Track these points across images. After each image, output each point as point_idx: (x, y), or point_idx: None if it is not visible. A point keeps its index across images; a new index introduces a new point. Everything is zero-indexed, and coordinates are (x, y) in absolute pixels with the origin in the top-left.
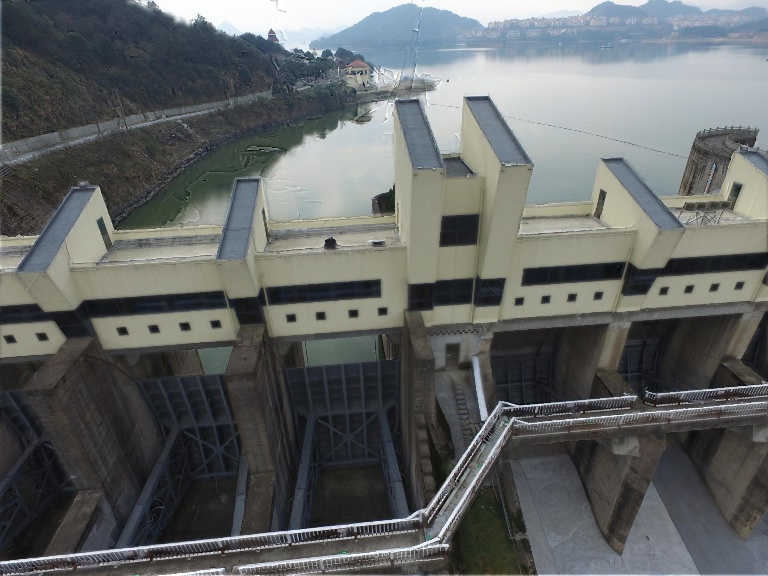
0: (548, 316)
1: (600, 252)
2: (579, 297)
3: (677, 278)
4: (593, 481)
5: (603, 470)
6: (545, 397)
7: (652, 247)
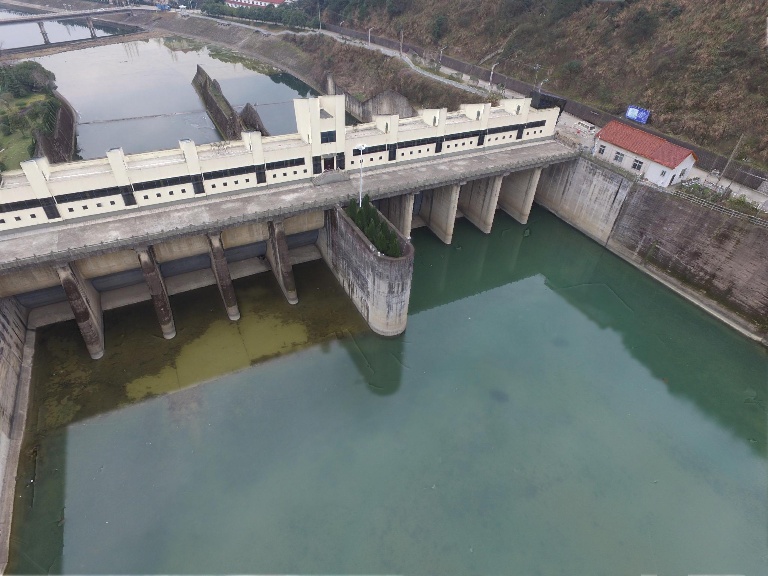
0: None
1: None
2: None
3: None
4: None
5: None
6: None
7: None
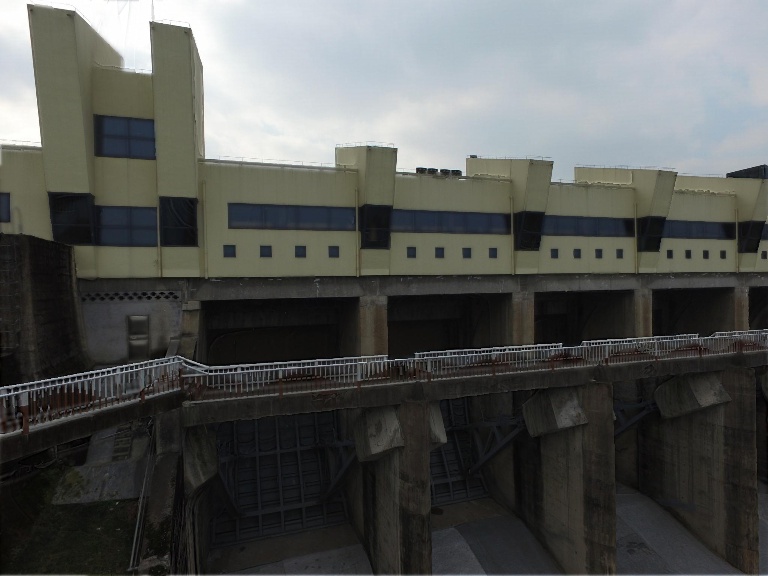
0: (276, 280)
1: (322, 192)
2: (310, 252)
3: (421, 236)
4: (380, 555)
5: (384, 519)
6: (324, 458)
7: (368, 171)
